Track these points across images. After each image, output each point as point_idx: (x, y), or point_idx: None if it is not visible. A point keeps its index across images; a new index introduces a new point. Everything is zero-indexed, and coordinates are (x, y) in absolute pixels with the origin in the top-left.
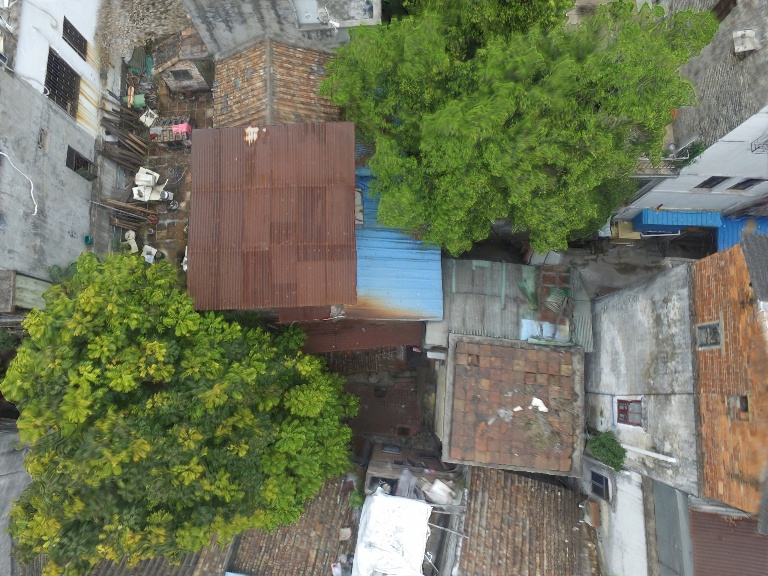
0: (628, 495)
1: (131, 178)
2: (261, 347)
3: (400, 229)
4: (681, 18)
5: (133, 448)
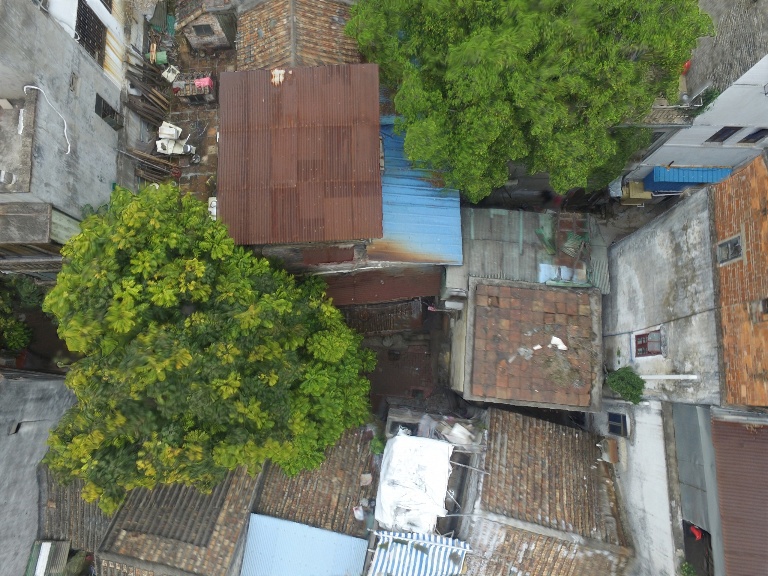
0: (647, 425)
1: (154, 133)
2: (286, 288)
3: (420, 176)
4: None
5: (176, 357)
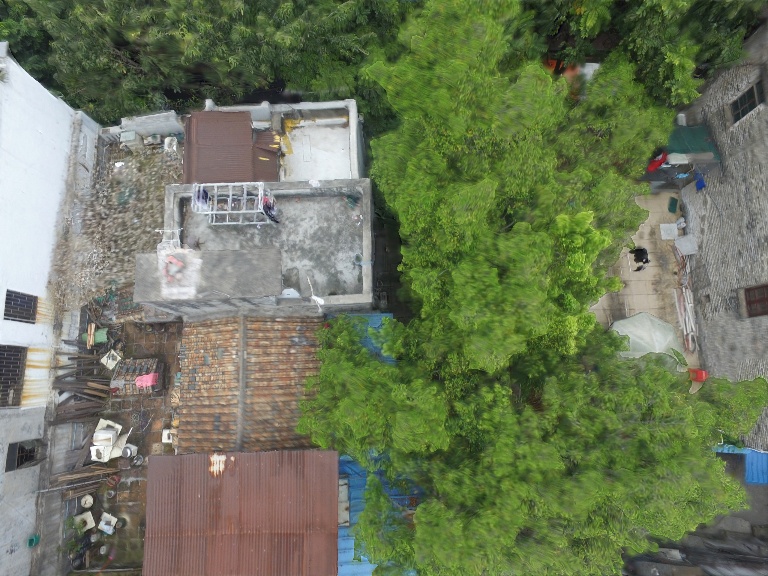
0: None
1: (91, 425)
2: None
3: None
4: (729, 399)
5: None
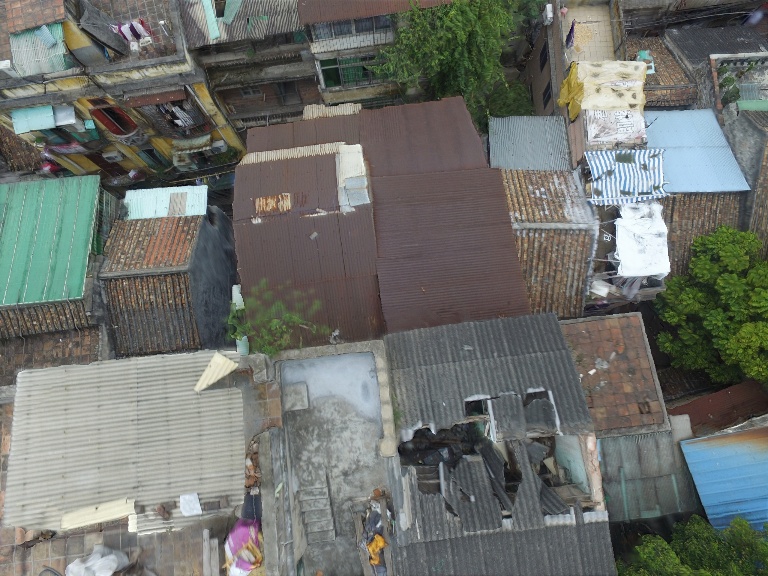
0: None
1: None
2: None
3: None
4: None
5: None
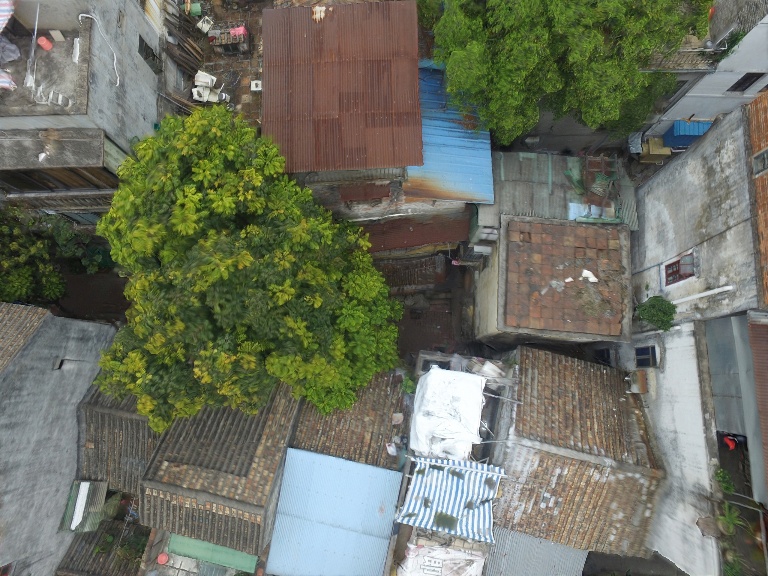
0: (678, 349)
1: (188, 83)
2: (325, 222)
3: (452, 119)
4: None
5: (237, 258)
